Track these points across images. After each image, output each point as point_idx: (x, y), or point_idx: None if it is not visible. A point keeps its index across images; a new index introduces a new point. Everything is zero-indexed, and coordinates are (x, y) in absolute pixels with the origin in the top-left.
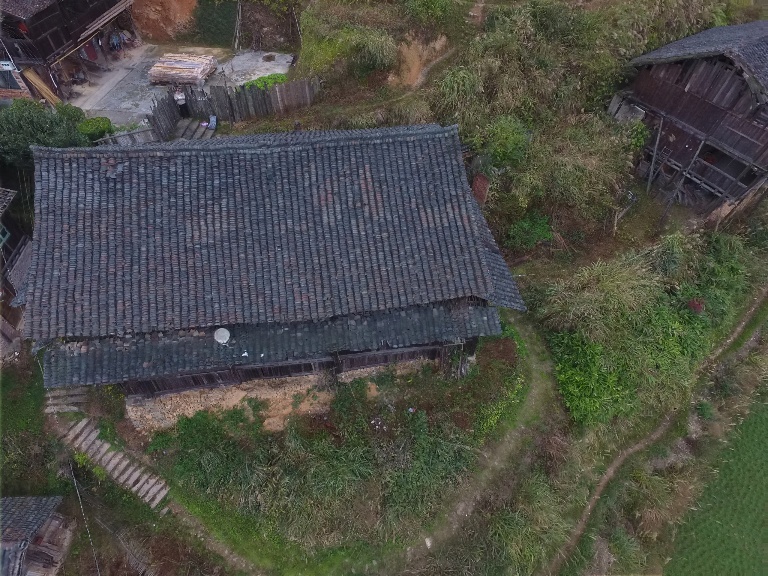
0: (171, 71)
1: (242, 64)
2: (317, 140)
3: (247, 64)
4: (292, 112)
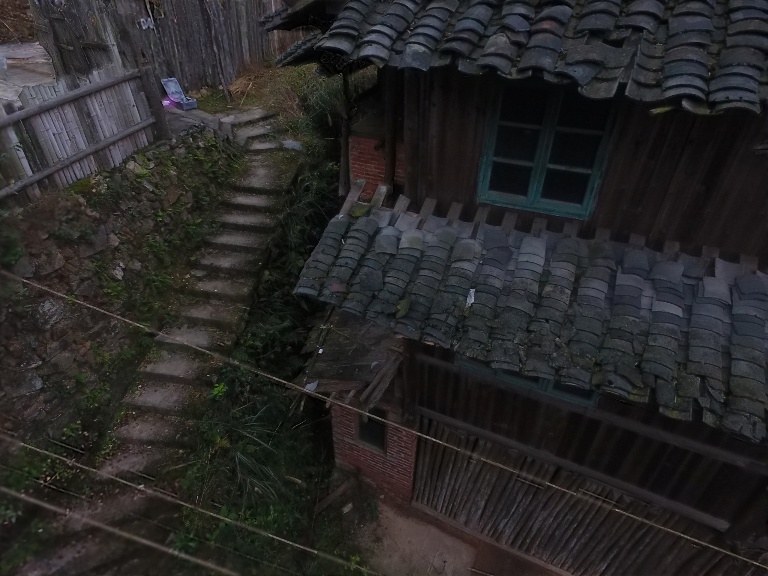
0: None
1: (14, 53)
2: None
3: (27, 52)
4: None
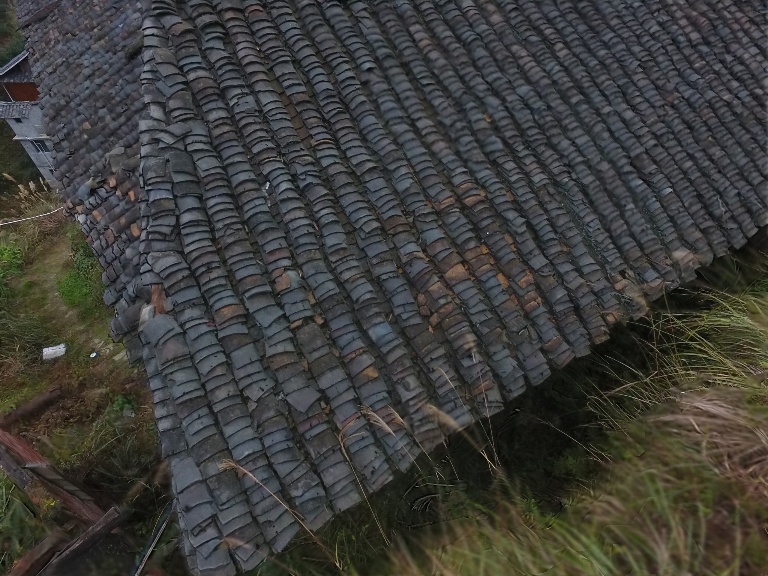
0: None
1: None
2: None
3: None
4: None
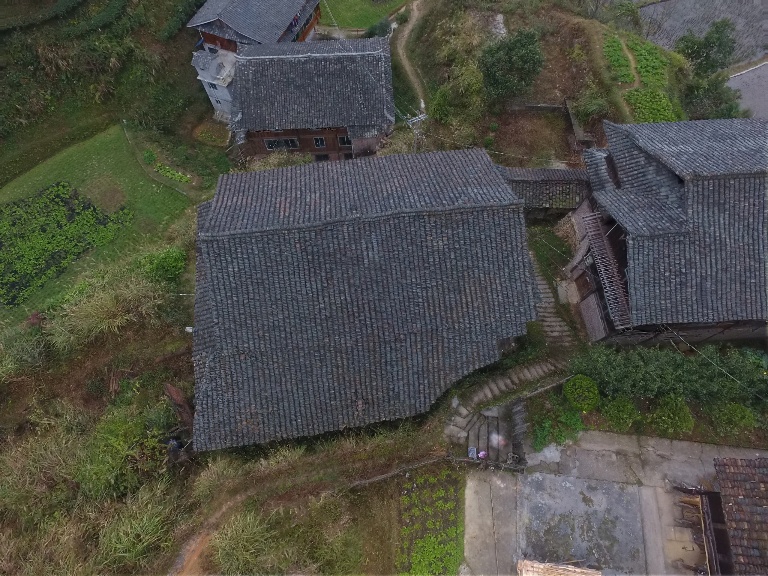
0: (567, 572)
1: None
2: (317, 222)
3: None
4: (376, 473)
